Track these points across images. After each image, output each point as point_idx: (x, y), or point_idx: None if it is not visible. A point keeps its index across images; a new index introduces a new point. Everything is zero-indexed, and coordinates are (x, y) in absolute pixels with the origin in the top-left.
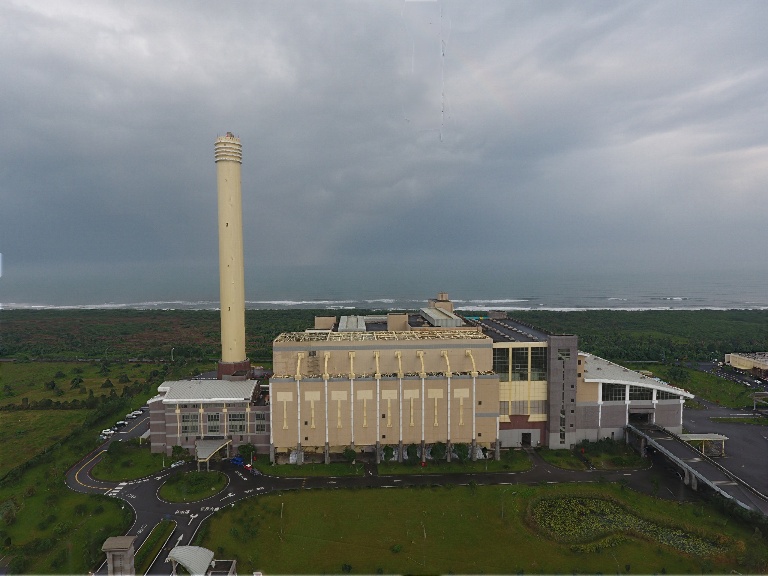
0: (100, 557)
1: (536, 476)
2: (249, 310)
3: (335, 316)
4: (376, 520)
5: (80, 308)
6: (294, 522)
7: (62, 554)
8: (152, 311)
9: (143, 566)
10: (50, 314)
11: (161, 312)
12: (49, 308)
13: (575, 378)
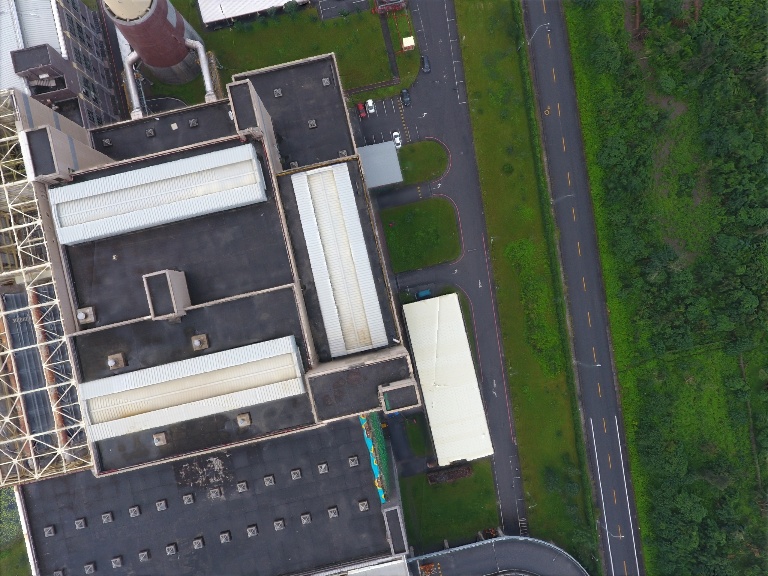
0: None
1: None
2: None
3: (245, 129)
4: None
5: None
6: None
7: None
8: None
9: None
10: None
11: None
12: None
13: None
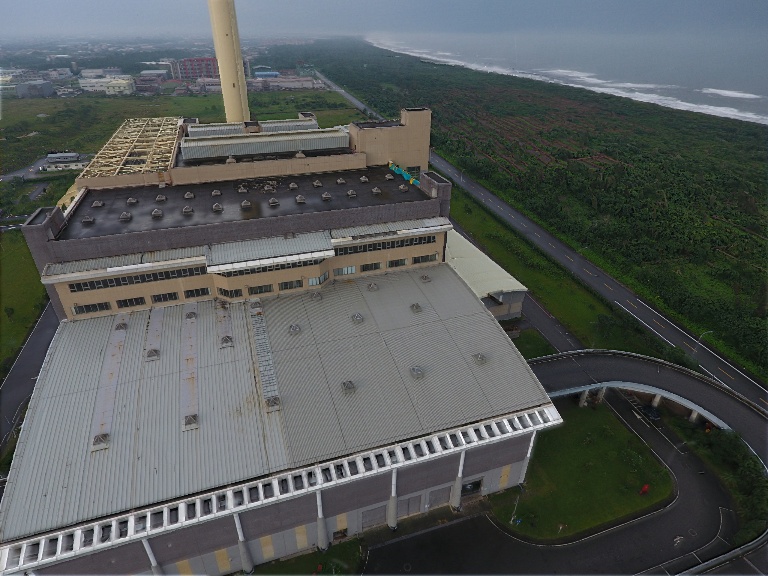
0: (27, 213)
1: (29, 365)
2: (699, 114)
3: None
4: (4, 279)
5: (560, 83)
6: (26, 251)
7: (30, 204)
8: (599, 96)
9: (7, 224)
10: (529, 85)
11: (601, 98)
12: (540, 79)
13: (54, 304)
